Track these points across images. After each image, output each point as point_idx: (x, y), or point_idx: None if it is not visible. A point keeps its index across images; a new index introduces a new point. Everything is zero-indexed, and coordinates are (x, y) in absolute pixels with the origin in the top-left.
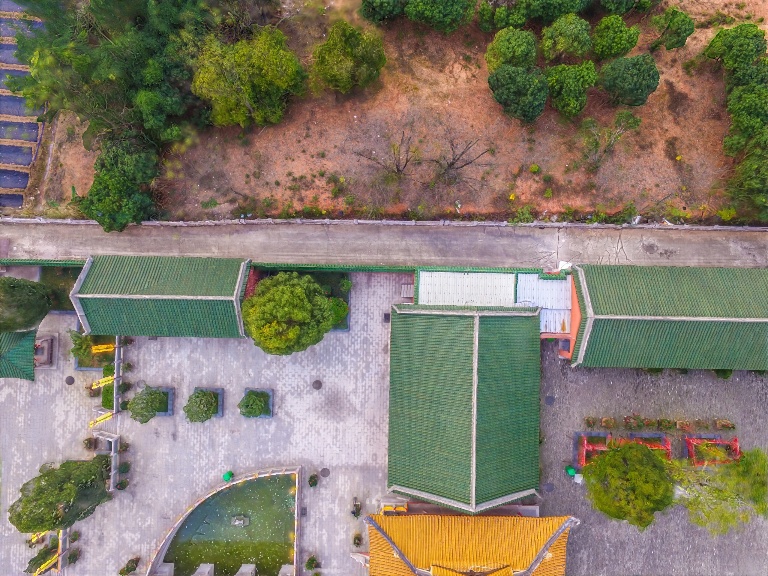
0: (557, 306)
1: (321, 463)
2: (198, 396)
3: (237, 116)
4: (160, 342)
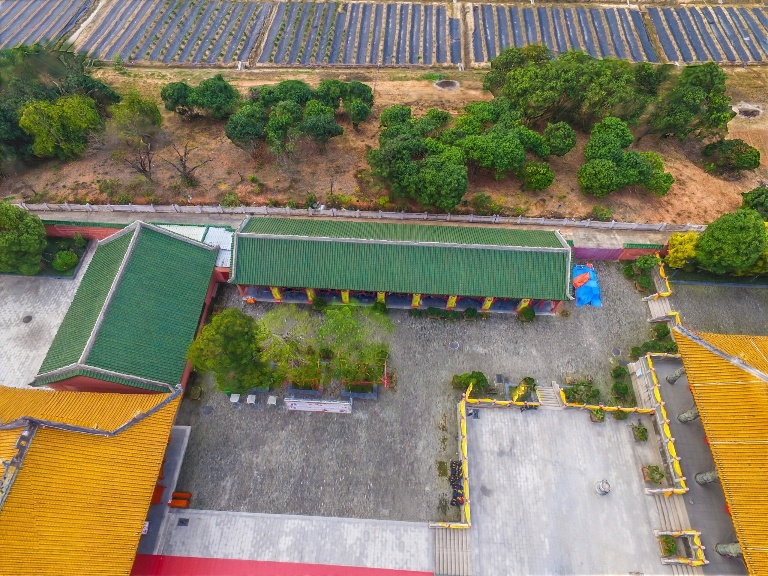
0: None
1: None
2: None
3: (47, 143)
4: None
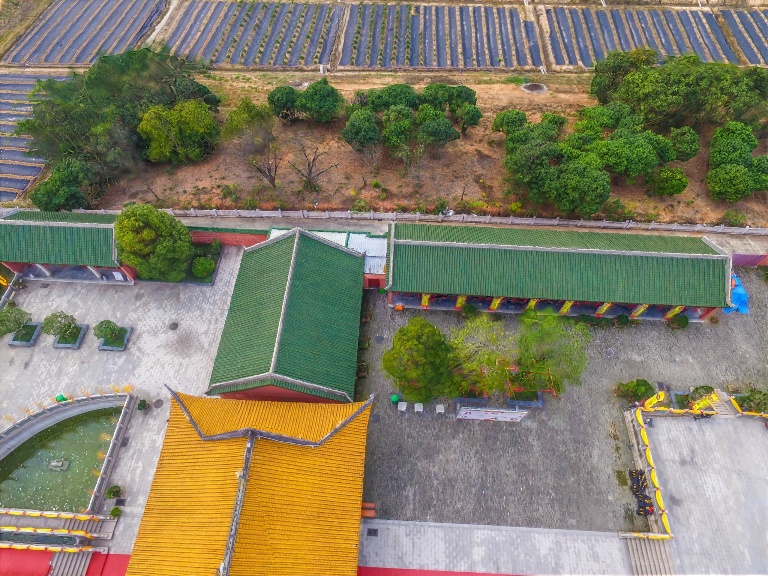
0: (380, 255)
1: (157, 394)
2: (60, 312)
3: (165, 148)
4: (49, 289)
